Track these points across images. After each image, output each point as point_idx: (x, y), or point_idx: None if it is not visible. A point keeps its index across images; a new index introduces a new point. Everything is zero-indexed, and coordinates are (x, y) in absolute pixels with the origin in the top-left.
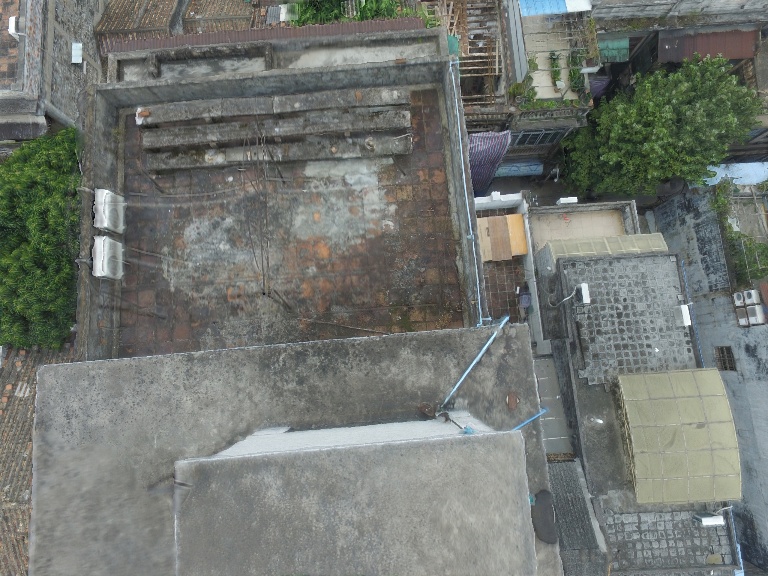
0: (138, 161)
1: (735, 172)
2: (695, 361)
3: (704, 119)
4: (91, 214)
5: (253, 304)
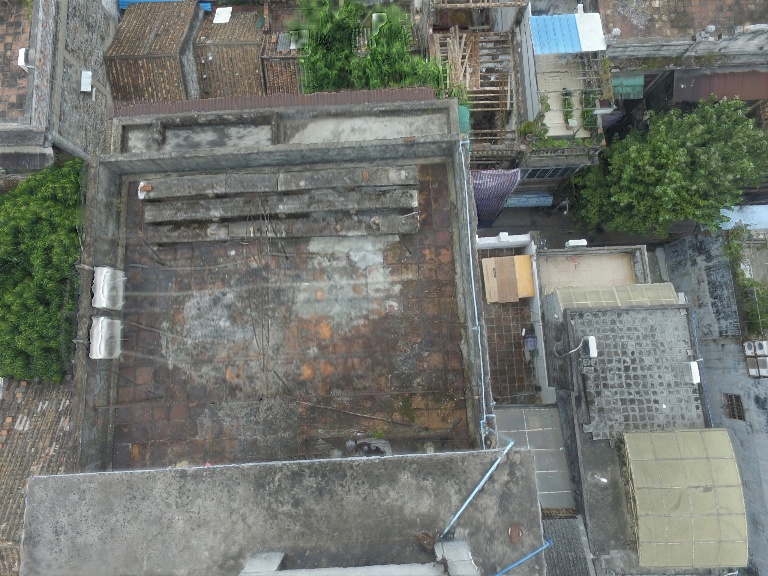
0: (140, 231)
1: (749, 214)
2: (703, 419)
3: (719, 164)
4: (90, 292)
5: (252, 385)
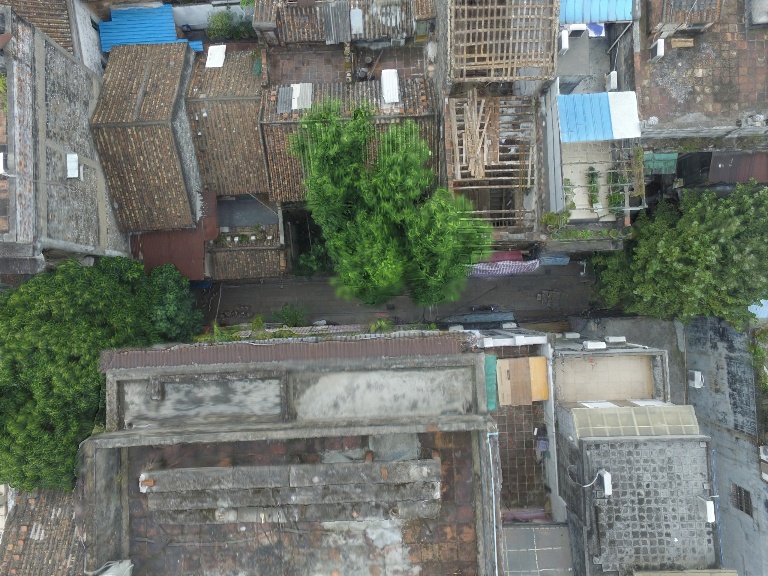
0: (143, 501)
1: None
2: (714, 553)
3: (753, 265)
4: None
5: None
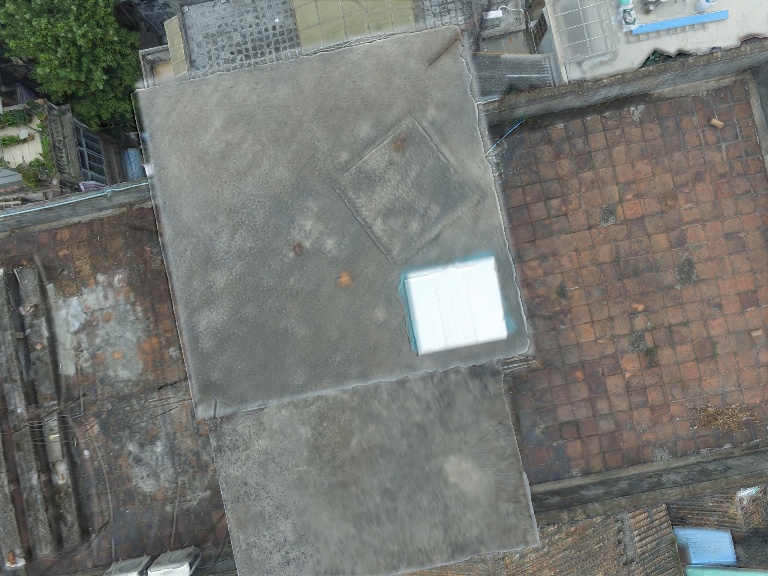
0: (77, 556)
1: None
2: None
3: None
4: None
5: None
